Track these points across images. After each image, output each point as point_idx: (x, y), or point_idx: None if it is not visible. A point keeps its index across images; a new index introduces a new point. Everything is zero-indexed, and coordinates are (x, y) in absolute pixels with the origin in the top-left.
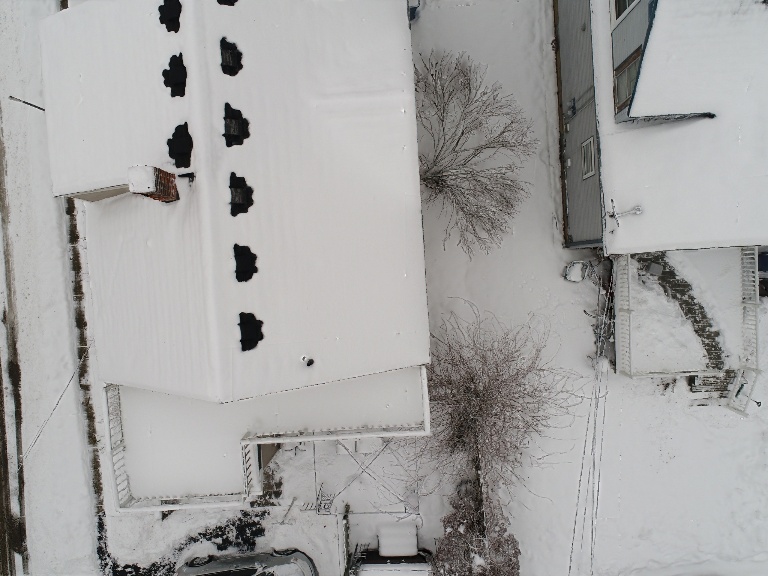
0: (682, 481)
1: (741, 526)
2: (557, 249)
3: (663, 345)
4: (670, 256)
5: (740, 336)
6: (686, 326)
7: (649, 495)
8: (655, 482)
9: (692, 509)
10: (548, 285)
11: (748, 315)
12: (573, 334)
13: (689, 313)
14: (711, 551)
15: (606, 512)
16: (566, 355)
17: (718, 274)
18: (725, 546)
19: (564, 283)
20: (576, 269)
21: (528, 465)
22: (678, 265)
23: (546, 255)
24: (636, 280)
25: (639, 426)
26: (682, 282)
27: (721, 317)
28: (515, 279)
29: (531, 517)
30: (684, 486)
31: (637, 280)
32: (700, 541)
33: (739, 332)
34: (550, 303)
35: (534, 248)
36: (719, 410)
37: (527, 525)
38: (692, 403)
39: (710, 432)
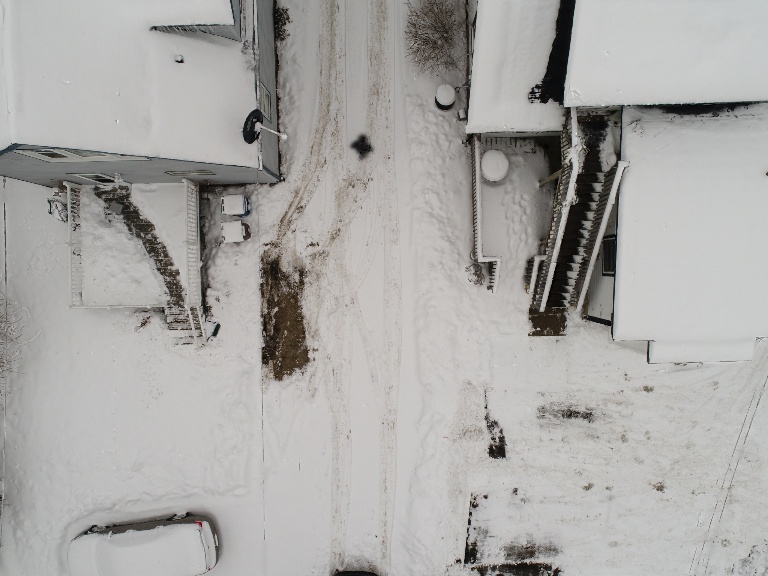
0: (172, 417)
1: (219, 460)
2: (53, 190)
3: (116, 280)
4: (132, 196)
5: (192, 274)
6: (143, 263)
7: (141, 429)
8: (147, 417)
9: (181, 444)
10: (45, 224)
11: (191, 253)
12: (68, 272)
13: (152, 252)
14: (197, 485)
15: (103, 445)
16: (62, 292)
17: (172, 214)
18: (208, 480)
19: (58, 222)
20: (58, 208)
21: (30, 398)
22: (139, 205)
23: (42, 195)
24: (98, 218)
25: (130, 362)
26: (146, 222)
27: (174, 255)
28: (16, 218)
29: (33, 448)
30: (174, 422)
31: (102, 218)
32: (186, 475)
33: (192, 270)
34: (47, 241)
35: (32, 188)
36: (204, 349)
37: (29, 456)
38: (178, 341)
39: (196, 370)
